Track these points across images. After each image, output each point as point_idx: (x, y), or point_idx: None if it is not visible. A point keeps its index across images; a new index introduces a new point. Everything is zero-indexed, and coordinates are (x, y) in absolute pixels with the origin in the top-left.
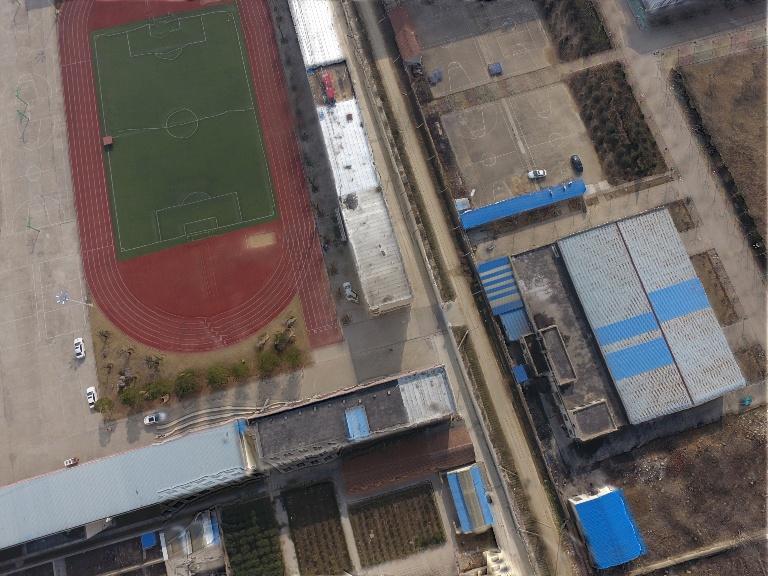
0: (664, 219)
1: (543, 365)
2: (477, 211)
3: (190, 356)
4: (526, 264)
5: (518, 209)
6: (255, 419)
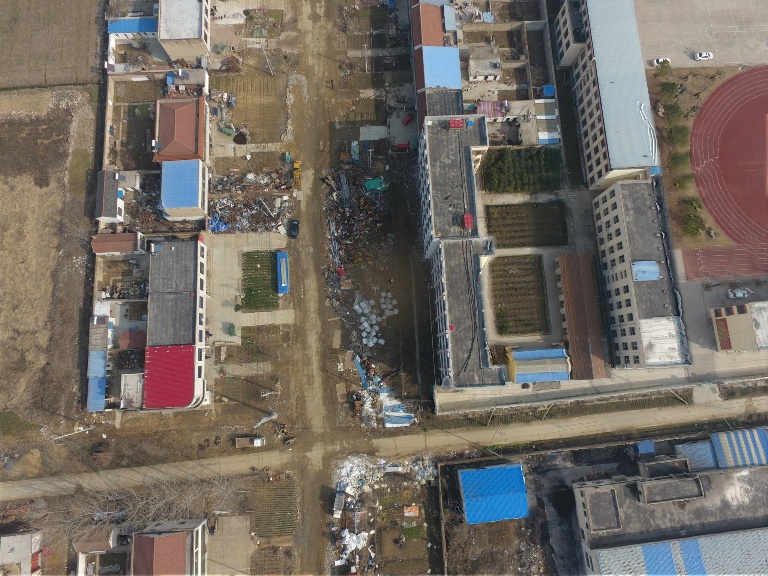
0: None
1: (656, 473)
2: None
3: (684, 140)
4: (766, 482)
5: None
6: (653, 182)
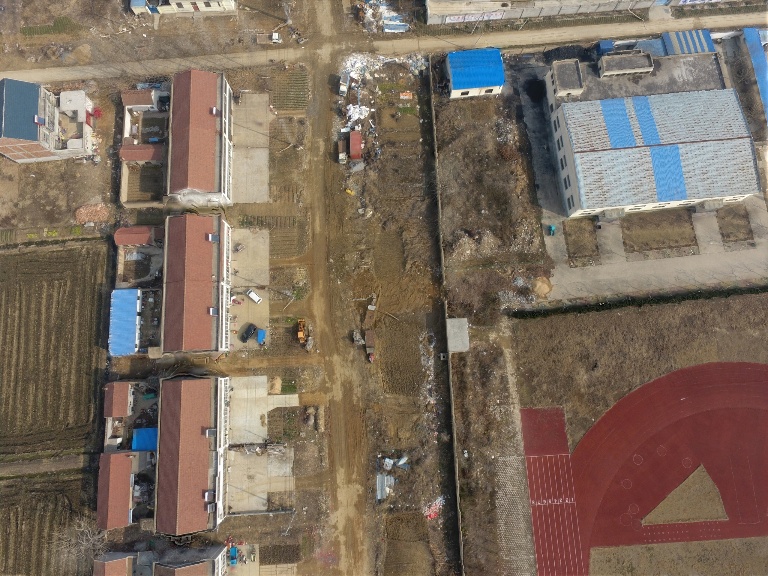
0: (749, 186)
1: None
2: (760, 41)
3: None
4: (708, 66)
5: (759, 76)
6: None
